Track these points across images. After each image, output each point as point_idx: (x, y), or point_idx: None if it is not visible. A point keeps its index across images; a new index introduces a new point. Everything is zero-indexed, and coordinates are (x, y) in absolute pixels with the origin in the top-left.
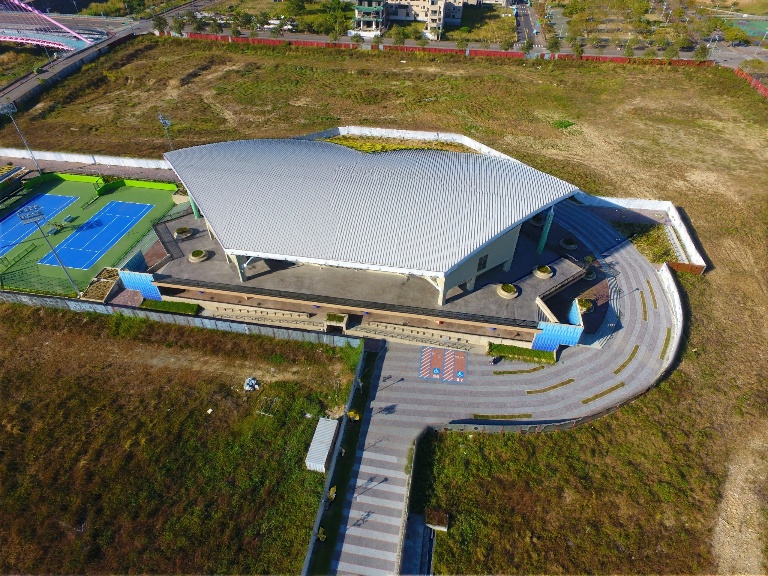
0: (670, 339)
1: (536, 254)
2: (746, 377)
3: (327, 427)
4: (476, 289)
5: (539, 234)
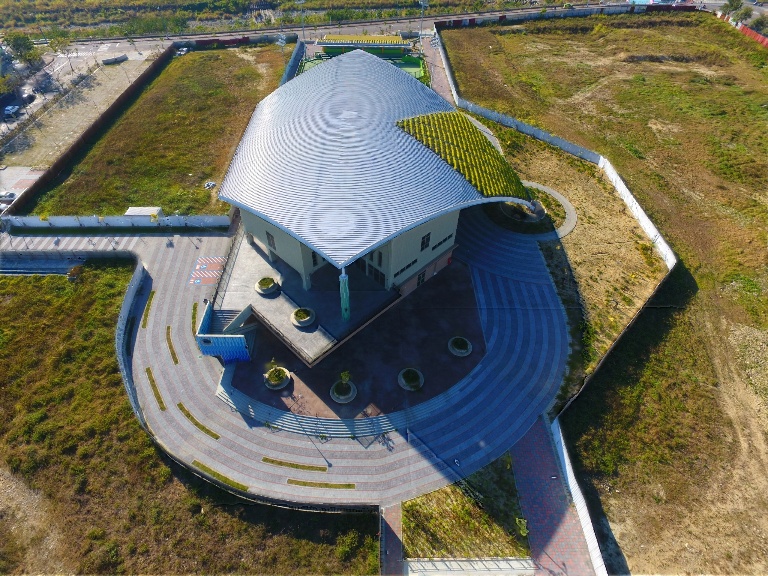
0: (226, 483)
1: (341, 315)
2: (147, 575)
3: (152, 211)
4: (272, 264)
5: (430, 348)
